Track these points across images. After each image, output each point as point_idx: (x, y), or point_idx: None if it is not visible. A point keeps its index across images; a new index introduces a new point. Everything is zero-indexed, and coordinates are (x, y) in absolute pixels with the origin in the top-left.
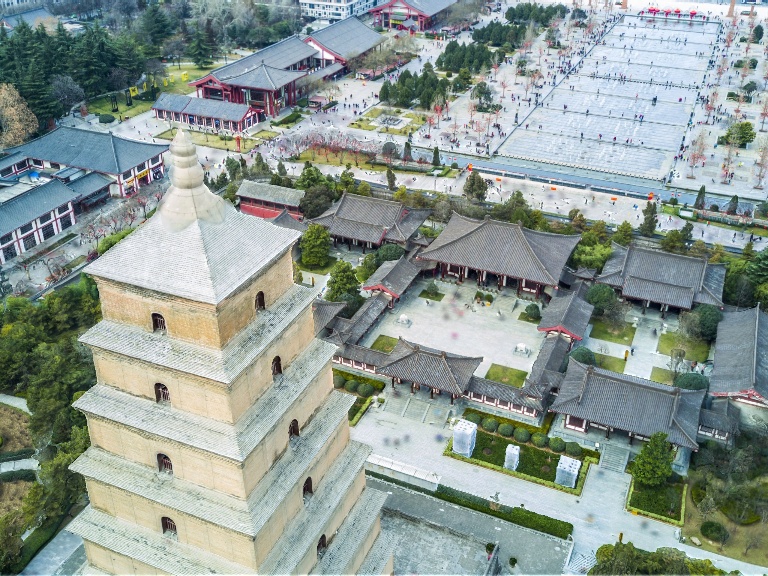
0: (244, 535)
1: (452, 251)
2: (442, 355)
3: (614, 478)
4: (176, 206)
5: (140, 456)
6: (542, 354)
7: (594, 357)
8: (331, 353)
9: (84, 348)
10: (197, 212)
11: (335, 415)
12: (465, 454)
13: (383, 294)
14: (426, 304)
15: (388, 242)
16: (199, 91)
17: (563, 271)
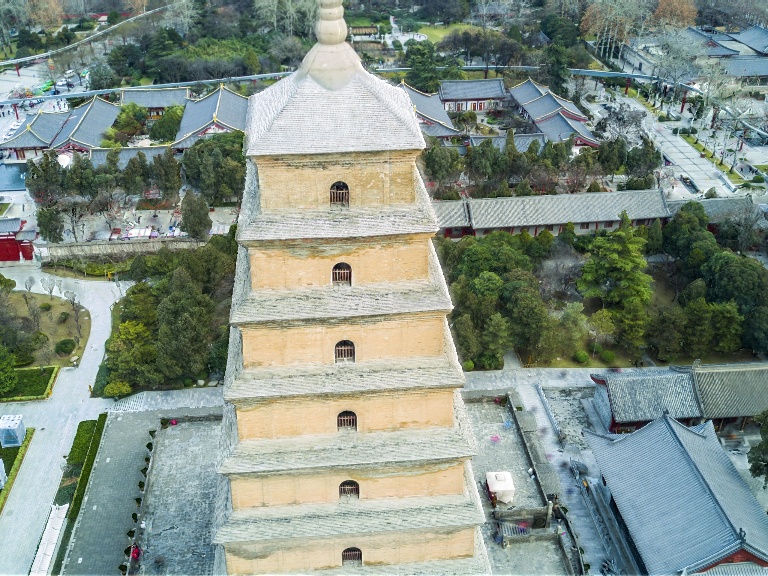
0: None
1: None
2: None
3: (2, 413)
4: None
5: None
6: None
7: None
8: None
9: None
10: None
11: None
12: None
13: None
14: None
15: None
16: None
17: None
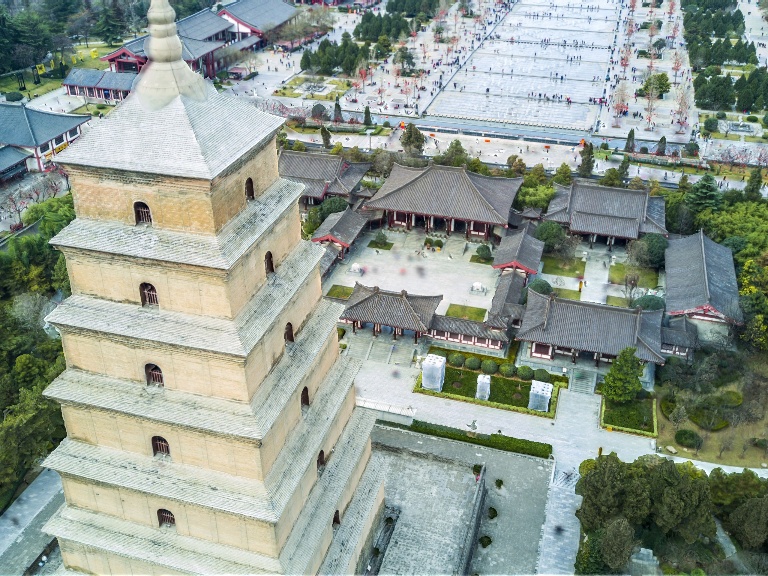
0: (249, 442)
1: (398, 198)
2: (403, 294)
3: (585, 399)
4: (155, 81)
5: (125, 370)
6: (500, 290)
7: (551, 288)
8: (320, 255)
9: (21, 313)
10: (179, 87)
11: (326, 322)
12: (435, 389)
13: (332, 244)
14: (376, 253)
15: (330, 196)
16: (112, 66)
17: (509, 213)
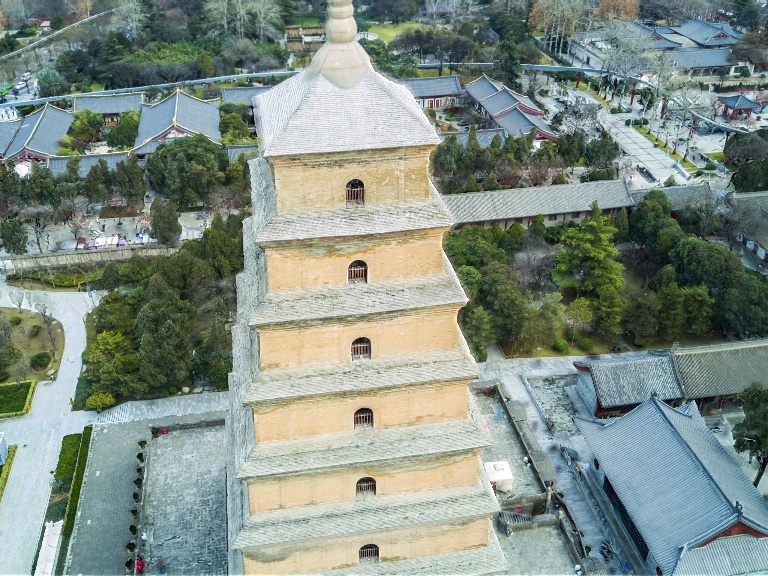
0: None
1: None
2: None
3: None
4: None
5: None
6: None
7: None
8: None
9: None
10: None
11: None
12: None
13: None
14: None
15: None
16: None
17: None
